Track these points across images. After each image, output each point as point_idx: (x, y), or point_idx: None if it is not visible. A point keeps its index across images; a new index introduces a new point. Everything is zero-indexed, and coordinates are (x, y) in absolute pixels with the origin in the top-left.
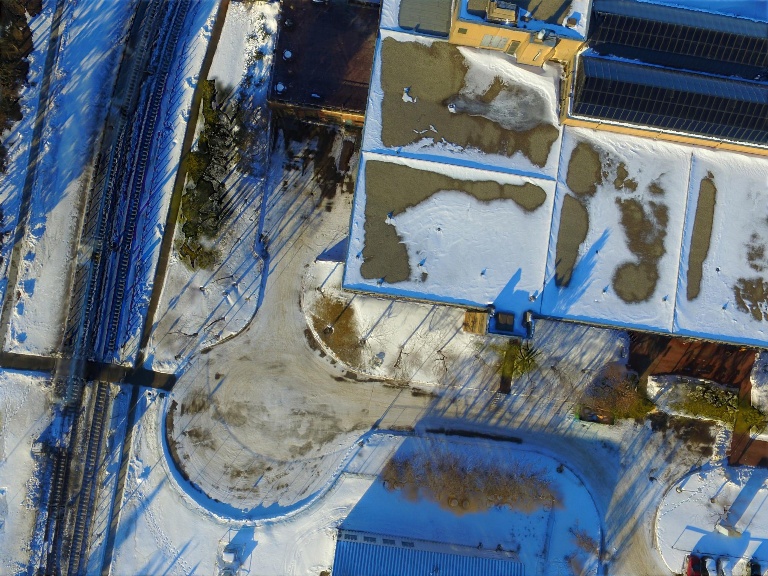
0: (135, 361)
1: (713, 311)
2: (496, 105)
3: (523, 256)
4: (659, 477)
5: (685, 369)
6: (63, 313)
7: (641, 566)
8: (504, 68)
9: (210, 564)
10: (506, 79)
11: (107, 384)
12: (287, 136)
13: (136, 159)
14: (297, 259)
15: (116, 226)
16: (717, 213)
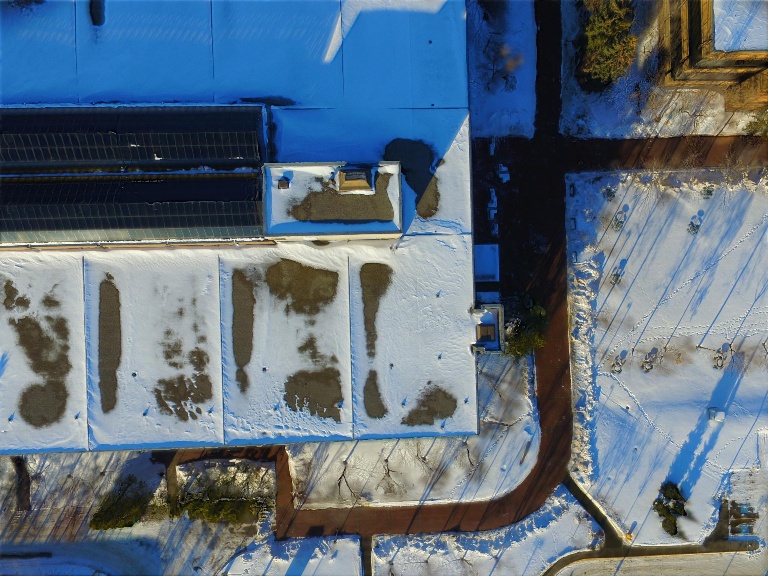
0: None
1: (134, 419)
2: None
3: None
4: (203, 565)
5: (214, 452)
6: None
7: None
8: None
9: None
10: None
11: None
12: None
13: None
14: None
15: None
16: (124, 315)
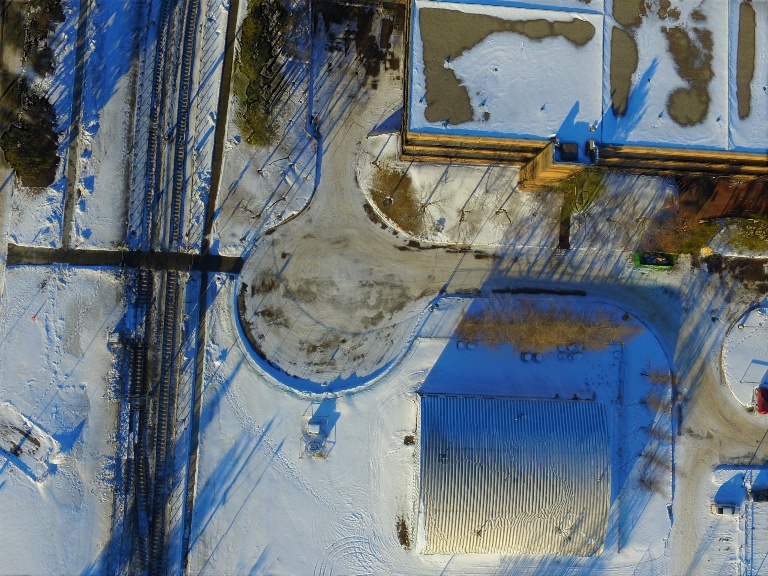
0: (201, 248)
1: (765, 128)
2: None
3: (579, 89)
4: (720, 316)
5: (734, 211)
6: (125, 207)
7: (713, 403)
8: None
9: (296, 439)
10: None
11: (176, 273)
12: (327, 19)
13: (181, 52)
14: (349, 137)
15: (168, 119)
16: (758, 35)
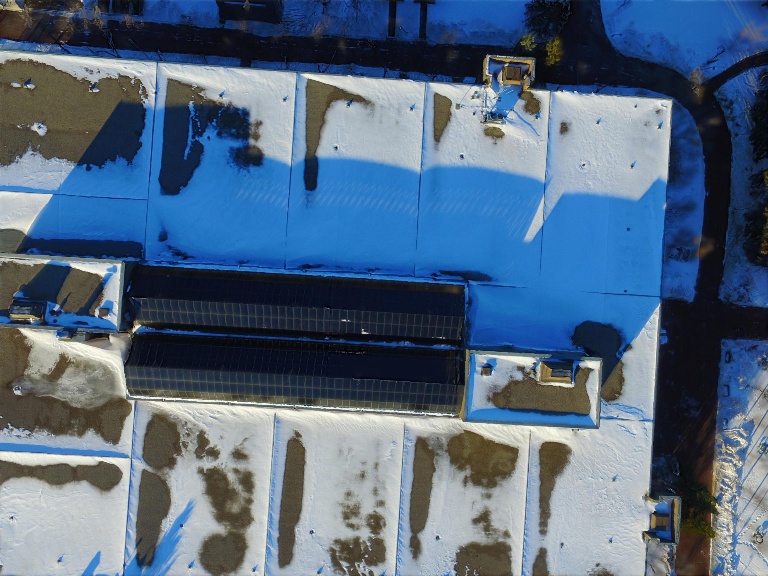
0: None
1: None
2: (64, 383)
3: (102, 538)
4: None
5: None
6: None
7: None
8: (68, 344)
9: None
10: (72, 355)
11: None
12: None
13: None
14: None
15: None
16: (308, 473)
